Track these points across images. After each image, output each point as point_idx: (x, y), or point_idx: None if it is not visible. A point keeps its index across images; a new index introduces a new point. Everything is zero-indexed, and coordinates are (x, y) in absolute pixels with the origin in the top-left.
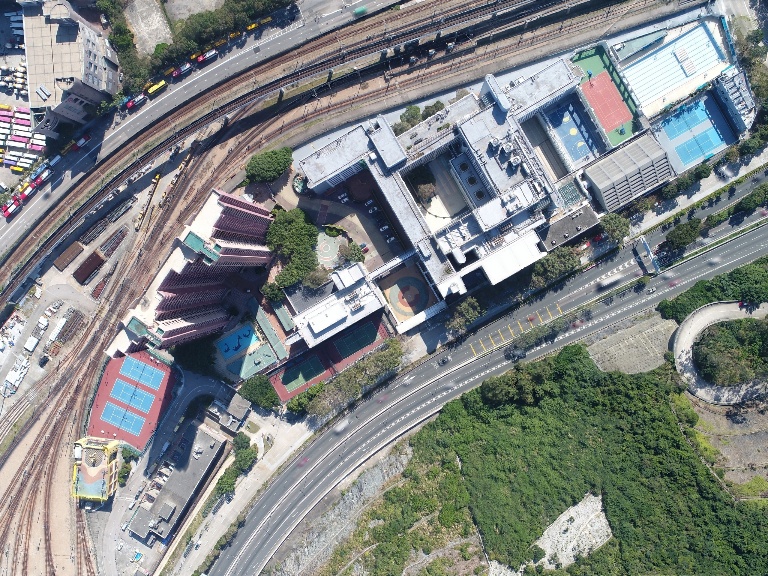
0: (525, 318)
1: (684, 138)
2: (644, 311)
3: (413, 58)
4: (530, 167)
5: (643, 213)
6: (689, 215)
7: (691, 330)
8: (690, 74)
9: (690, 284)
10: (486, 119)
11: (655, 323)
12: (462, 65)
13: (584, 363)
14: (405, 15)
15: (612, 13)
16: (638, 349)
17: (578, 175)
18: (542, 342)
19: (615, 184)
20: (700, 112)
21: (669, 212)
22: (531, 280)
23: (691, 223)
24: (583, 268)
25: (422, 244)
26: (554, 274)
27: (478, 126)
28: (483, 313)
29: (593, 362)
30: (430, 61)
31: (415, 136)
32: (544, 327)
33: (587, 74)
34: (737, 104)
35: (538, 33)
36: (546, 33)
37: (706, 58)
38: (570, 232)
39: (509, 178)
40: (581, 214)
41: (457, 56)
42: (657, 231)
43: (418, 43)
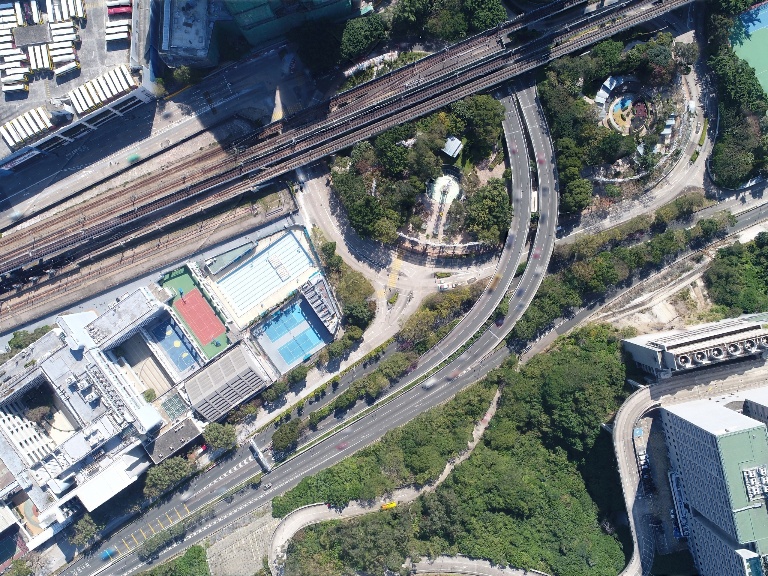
0: (155, 520)
1: (285, 340)
2: (263, 506)
3: (15, 286)
4: (107, 401)
5: (256, 412)
6: (298, 410)
7: (284, 535)
8: (285, 279)
9: (302, 477)
10: (65, 356)
11: (264, 522)
12: (69, 285)
13: (199, 568)
14: (7, 243)
15: (205, 228)
16: (245, 552)
17: (179, 389)
18: (173, 542)
19: (207, 399)
20: (297, 314)
21: (280, 409)
22: (143, 493)
23: (290, 425)
24: (205, 469)
25: (19, 478)
26: (164, 485)
27: (58, 363)
28: (101, 528)
29: (207, 566)
30: (37, 284)
31: (4, 374)
32: (165, 533)
33: (179, 292)
34: (320, 311)
35: (138, 250)
36: (145, 250)
37: (298, 263)
38: (175, 444)
39: (93, 410)
40: (183, 427)
41: (63, 277)
42: (270, 428)
43: (22, 269)
